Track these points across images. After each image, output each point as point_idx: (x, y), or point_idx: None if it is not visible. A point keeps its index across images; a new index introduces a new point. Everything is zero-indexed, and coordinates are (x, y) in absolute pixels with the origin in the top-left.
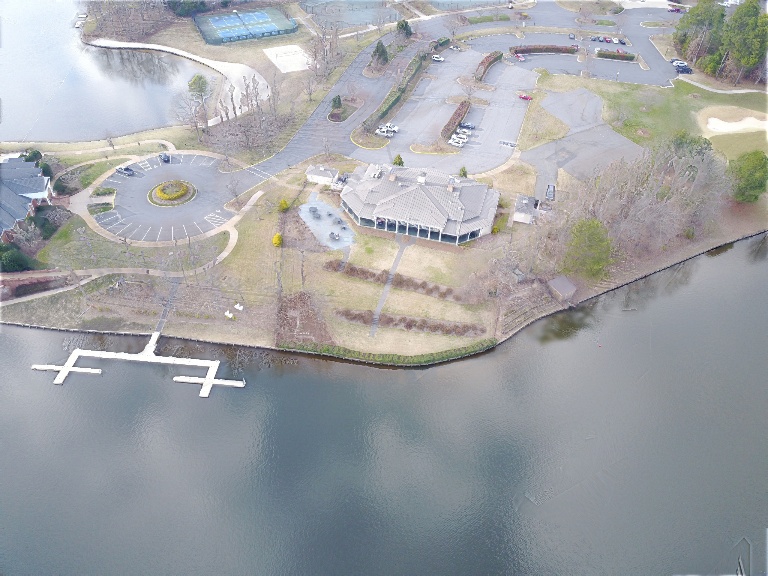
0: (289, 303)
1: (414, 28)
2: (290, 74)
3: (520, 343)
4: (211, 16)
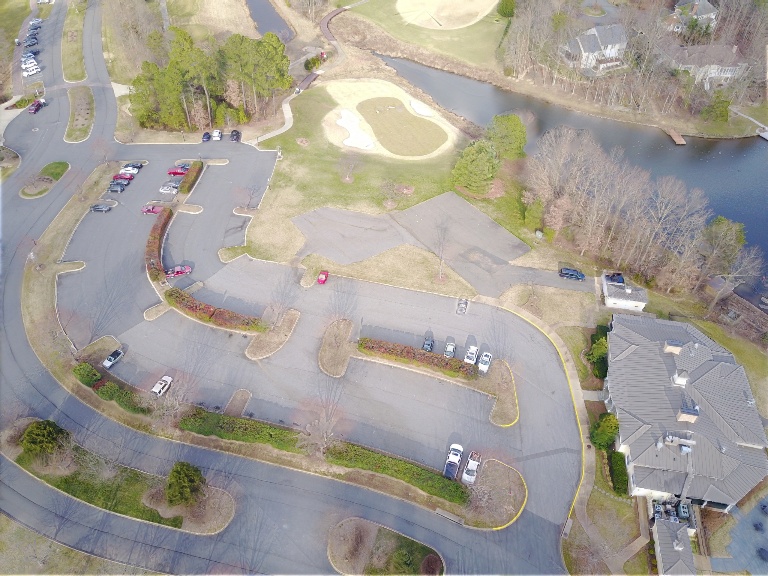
0: None
1: (5, 426)
2: None
3: None
4: None
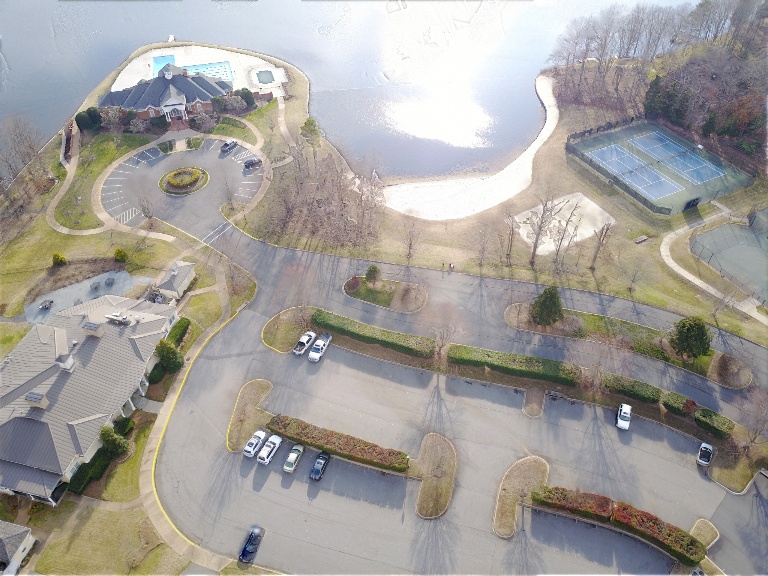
0: None
1: (745, 362)
2: (504, 228)
3: None
4: (667, 131)
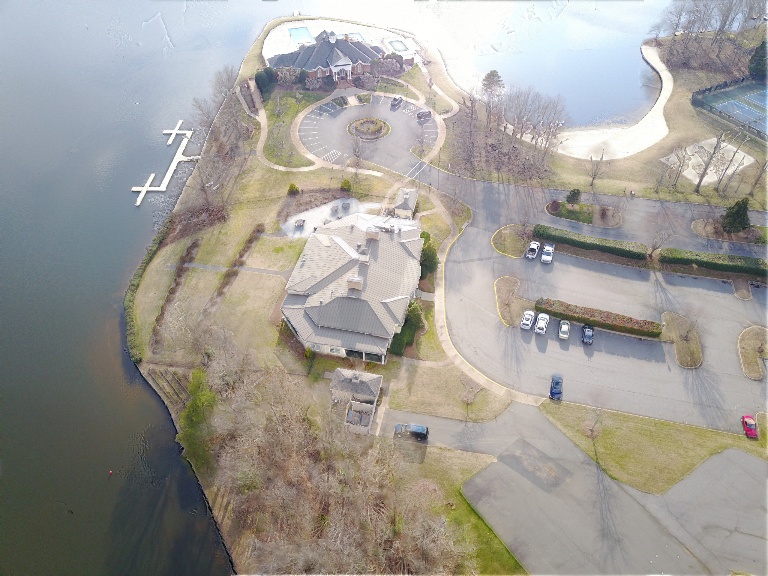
0: (216, 212)
1: None
2: (661, 165)
3: (135, 389)
4: None
